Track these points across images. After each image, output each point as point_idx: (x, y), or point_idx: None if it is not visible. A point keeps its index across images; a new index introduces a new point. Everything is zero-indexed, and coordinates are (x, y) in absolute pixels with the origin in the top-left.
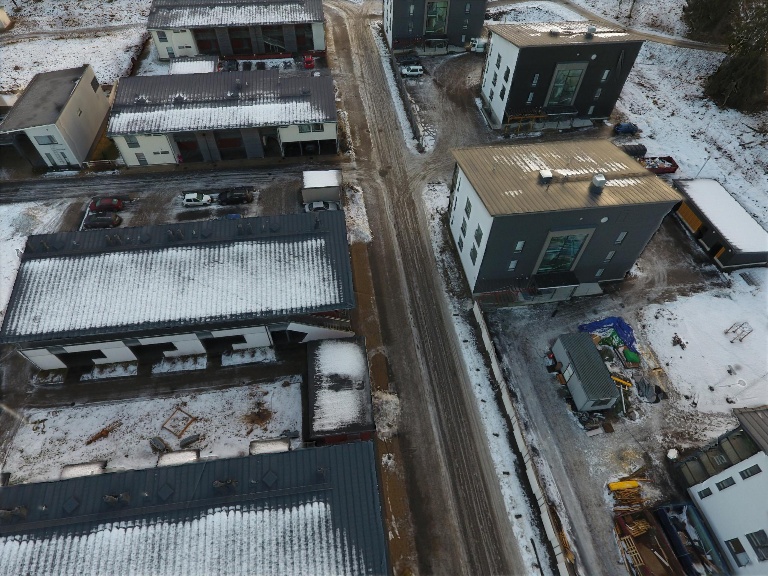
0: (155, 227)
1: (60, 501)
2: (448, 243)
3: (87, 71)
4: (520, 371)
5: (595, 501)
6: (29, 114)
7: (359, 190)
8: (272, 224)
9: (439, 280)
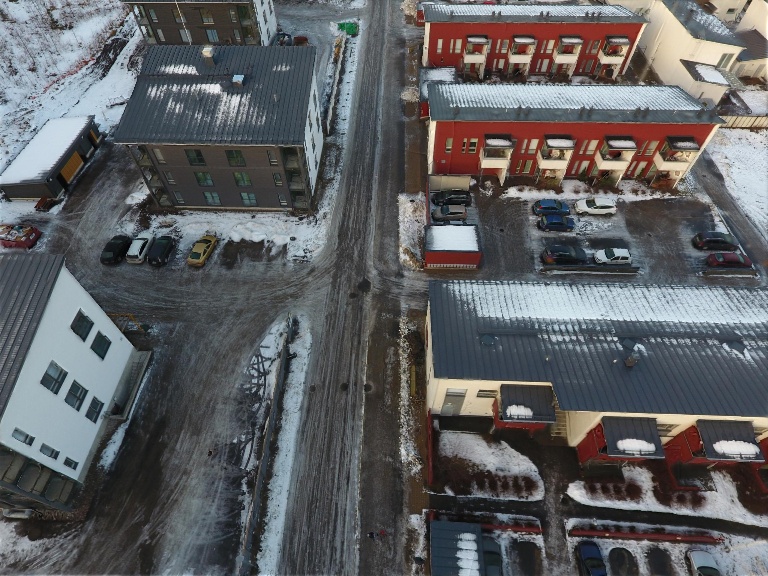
0: (610, 120)
1: (571, 19)
2: (322, 186)
3: None
4: None
5: None
6: None
7: (403, 254)
8: (499, 114)
9: (346, 157)
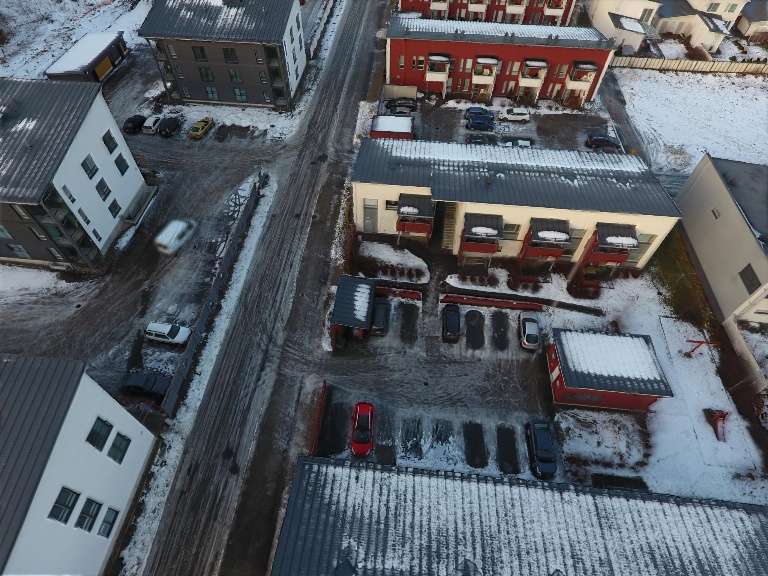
0: (527, 43)
1: None
2: (301, 93)
3: (765, 258)
4: (305, 37)
5: (306, 8)
6: (766, 184)
7: (356, 139)
8: (440, 36)
9: (323, 75)
